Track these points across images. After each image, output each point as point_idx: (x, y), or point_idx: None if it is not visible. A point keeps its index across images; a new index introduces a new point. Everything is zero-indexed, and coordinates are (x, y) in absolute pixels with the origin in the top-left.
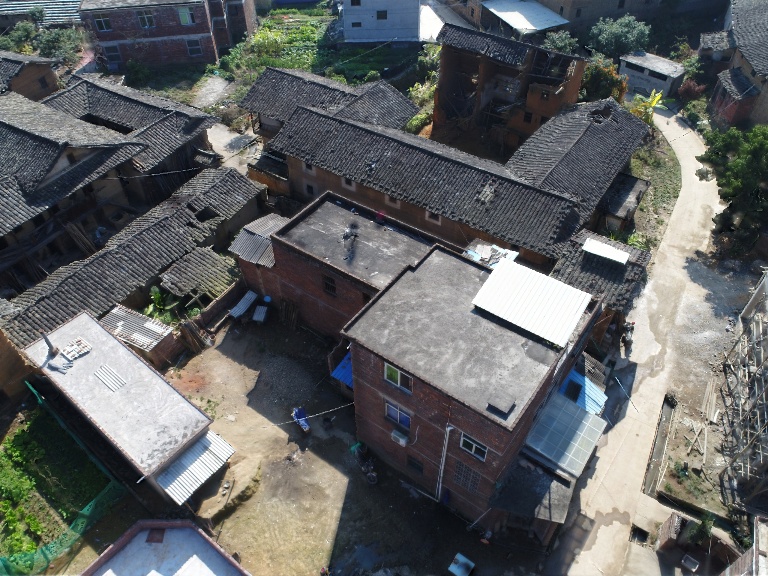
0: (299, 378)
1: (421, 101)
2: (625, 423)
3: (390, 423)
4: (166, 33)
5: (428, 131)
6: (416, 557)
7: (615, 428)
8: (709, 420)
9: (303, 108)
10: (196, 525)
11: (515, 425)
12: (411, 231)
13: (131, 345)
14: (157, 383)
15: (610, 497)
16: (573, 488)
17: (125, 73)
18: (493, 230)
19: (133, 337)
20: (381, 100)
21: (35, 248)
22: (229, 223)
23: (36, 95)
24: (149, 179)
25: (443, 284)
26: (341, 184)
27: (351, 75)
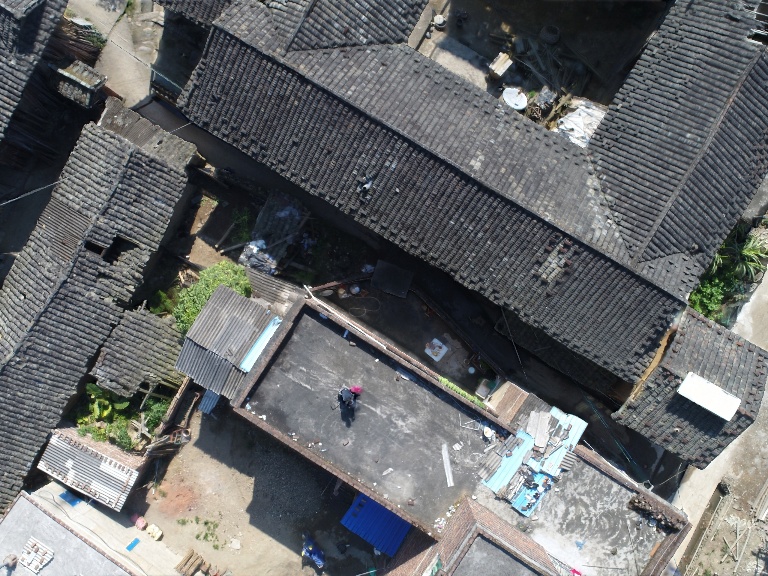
0: (302, 485)
1: None
2: None
3: None
4: None
5: None
6: None
7: None
8: (757, 518)
9: (225, 33)
10: None
11: None
12: None
13: None
14: None
15: None
16: None
17: None
18: (553, 329)
19: (93, 488)
20: None
21: None
22: None
23: None
24: (0, 145)
25: None
26: None
27: None
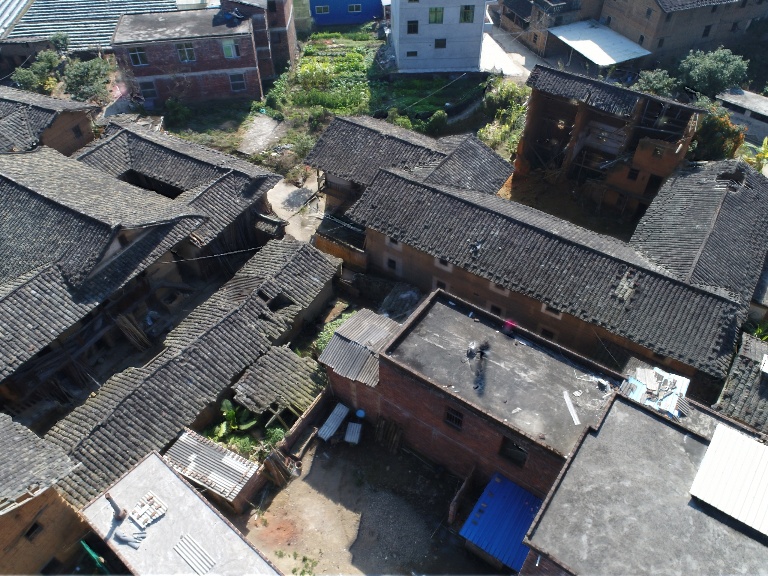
0: (410, 524)
1: (493, 144)
2: None
3: None
4: (207, 67)
5: (508, 182)
6: None
7: None
8: None
9: (387, 172)
10: None
11: None
12: (549, 347)
13: (209, 491)
14: (255, 563)
15: None
16: None
17: (161, 111)
18: (638, 337)
19: (210, 479)
20: (472, 159)
21: (81, 349)
22: (304, 310)
23: (69, 146)
24: (205, 252)
25: (639, 457)
26: (434, 263)
27: (409, 111)
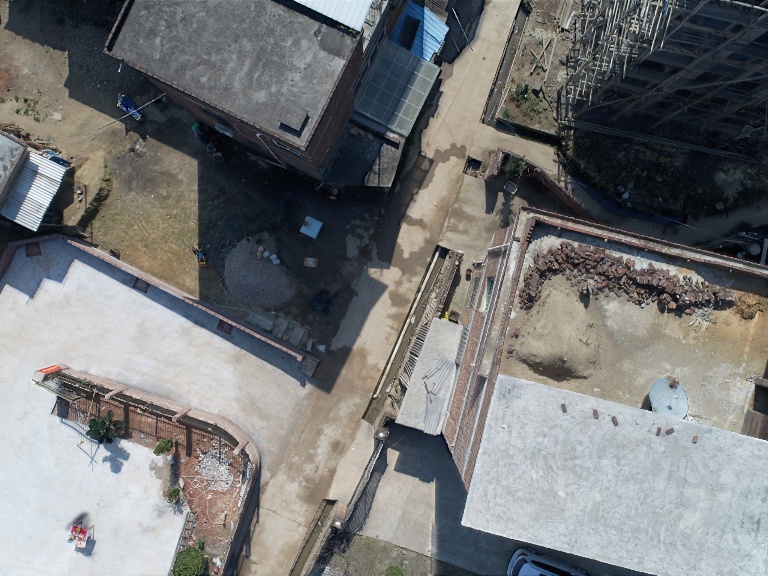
0: None
1: None
2: (473, 46)
3: (211, 116)
4: None
5: None
6: (273, 222)
7: (462, 54)
8: (561, 27)
9: None
10: (63, 237)
11: (308, 143)
12: None
13: None
14: None
15: (450, 133)
16: (402, 148)
17: None
18: None
19: None
20: None
21: None
22: None
23: None
24: None
25: None
26: None
27: None
